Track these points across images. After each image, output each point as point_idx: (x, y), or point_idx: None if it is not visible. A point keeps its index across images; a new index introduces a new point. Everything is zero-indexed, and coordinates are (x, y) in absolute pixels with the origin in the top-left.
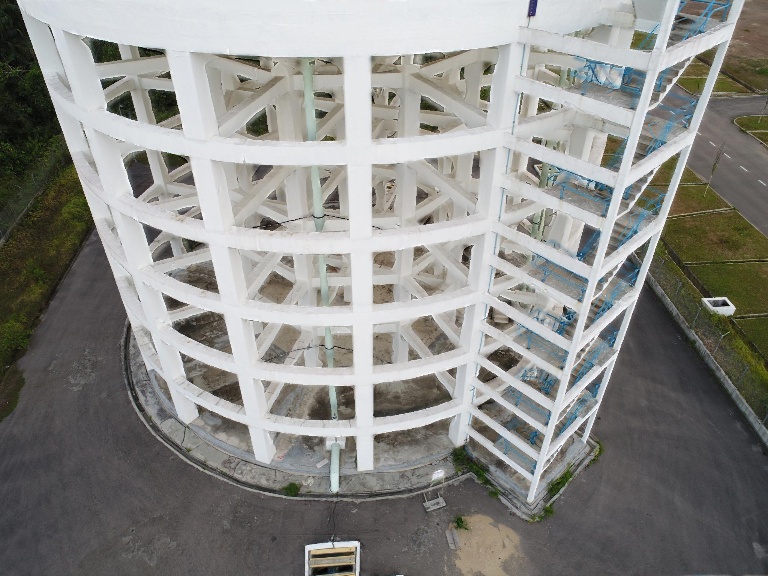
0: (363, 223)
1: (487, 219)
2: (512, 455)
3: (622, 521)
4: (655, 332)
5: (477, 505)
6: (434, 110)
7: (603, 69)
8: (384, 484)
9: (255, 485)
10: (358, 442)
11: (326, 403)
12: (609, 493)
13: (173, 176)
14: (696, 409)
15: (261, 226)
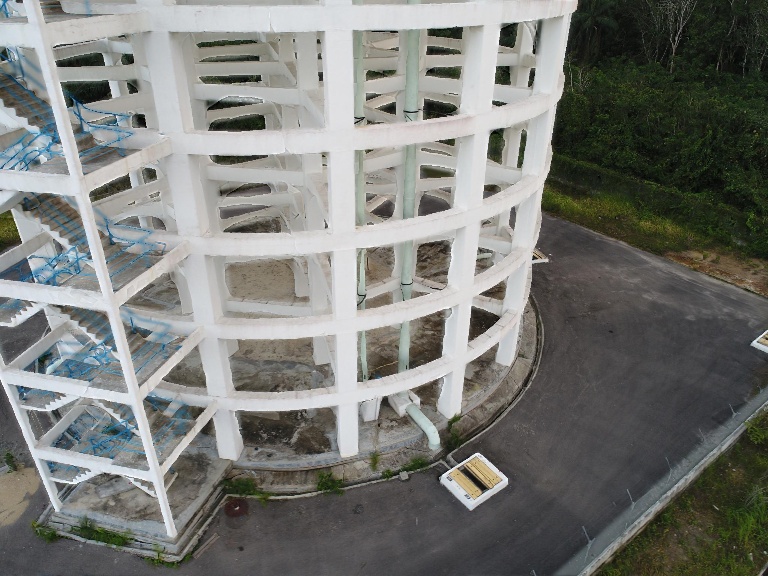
0: None
1: None
2: (78, 448)
3: None
4: (495, 575)
5: None
6: None
7: None
8: None
9: None
10: None
11: (149, 332)
12: None
13: None
14: None
15: None
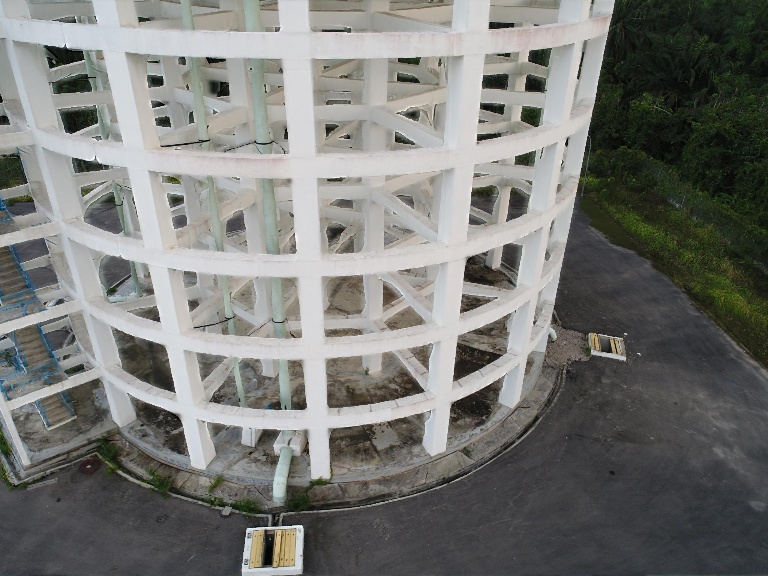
0: None
1: None
2: None
3: None
4: None
5: None
6: None
7: None
8: None
9: None
10: None
11: None
12: None
13: (401, 146)
14: None
15: None
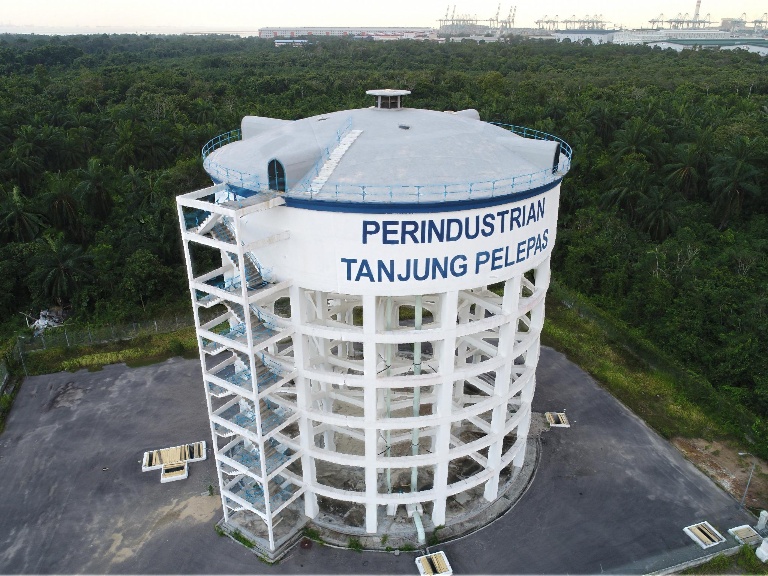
0: None
1: None
2: (241, 493)
3: (215, 574)
4: None
5: None
6: (765, 425)
7: (292, 309)
8: None
9: None
10: None
11: (292, 428)
12: (236, 568)
13: None
14: None
15: None
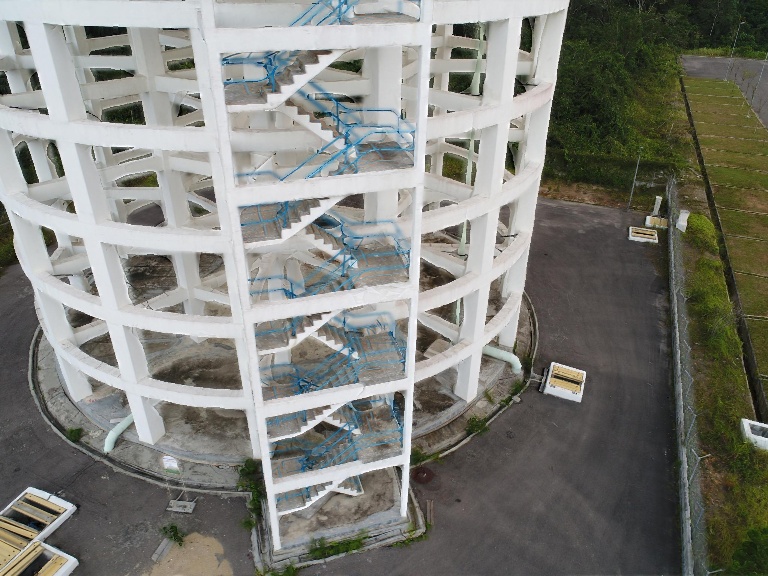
0: (56, 102)
1: (205, 132)
2: None
3: None
4: (633, 435)
5: (223, 528)
6: None
7: None
8: (154, 464)
9: (55, 418)
10: (129, 400)
11: (179, 371)
12: None
13: None
14: (611, 546)
15: (19, 108)
